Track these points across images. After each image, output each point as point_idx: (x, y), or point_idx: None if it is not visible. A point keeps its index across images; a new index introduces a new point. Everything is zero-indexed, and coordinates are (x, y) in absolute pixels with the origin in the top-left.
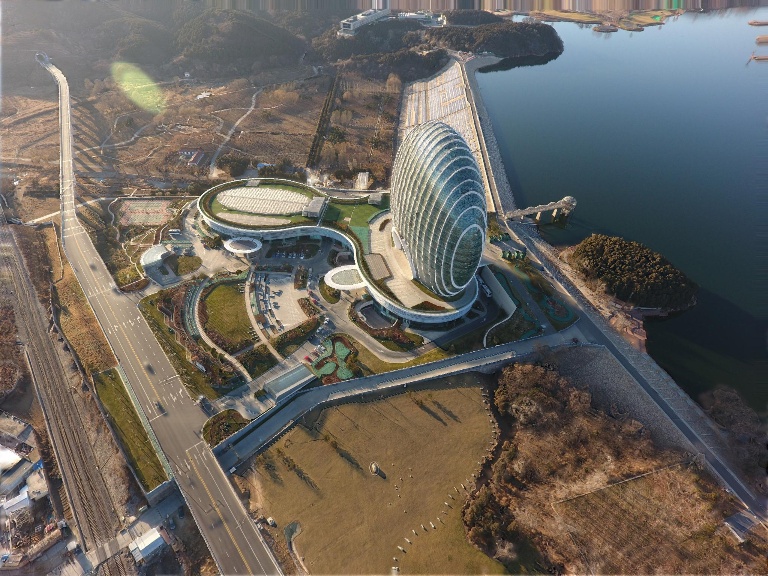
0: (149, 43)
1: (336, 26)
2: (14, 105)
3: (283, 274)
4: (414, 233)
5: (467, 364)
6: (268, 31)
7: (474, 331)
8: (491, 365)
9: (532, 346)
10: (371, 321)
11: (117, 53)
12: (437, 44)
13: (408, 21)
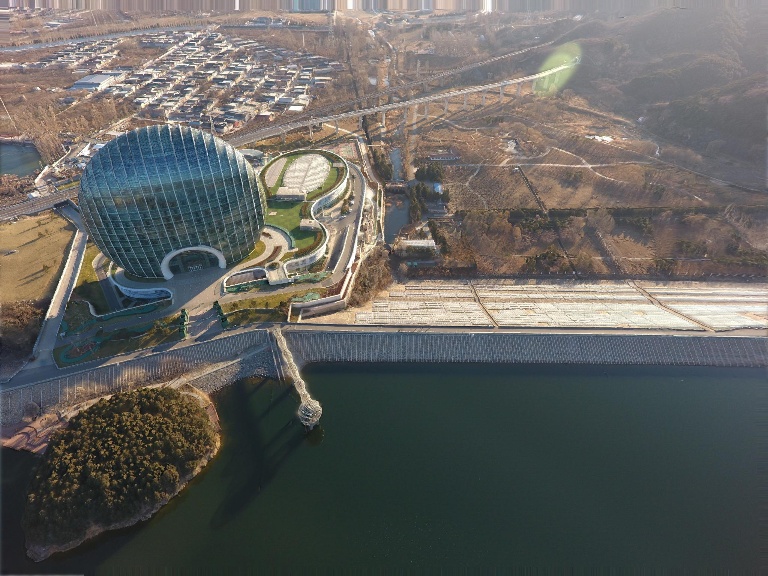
0: (671, 81)
1: None
2: None
3: None
4: None
5: (63, 290)
6: None
7: (105, 302)
8: None
9: None
10: None
11: None
12: None
13: None
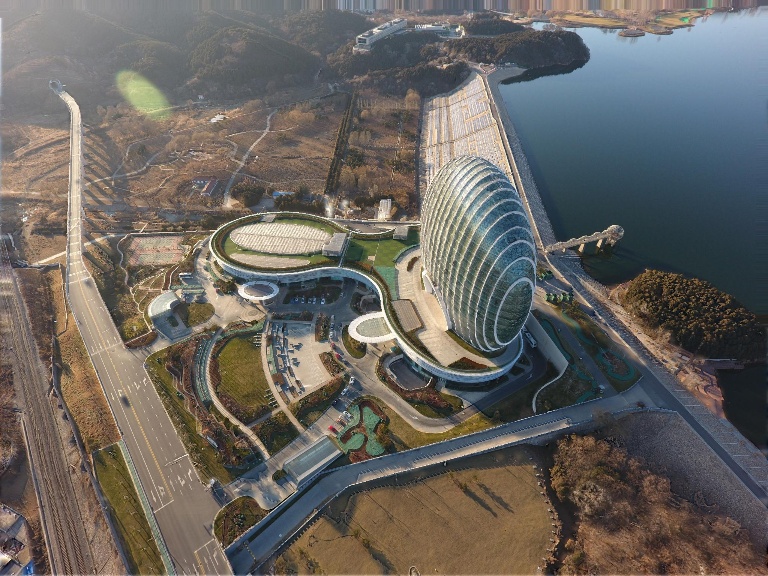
0: (162, 66)
1: (351, 41)
2: (27, 135)
3: (302, 323)
4: (450, 283)
5: (516, 435)
6: (282, 49)
7: (520, 391)
8: (544, 436)
9: (592, 414)
10: (401, 378)
11: (130, 77)
12: (457, 56)
13: (425, 33)
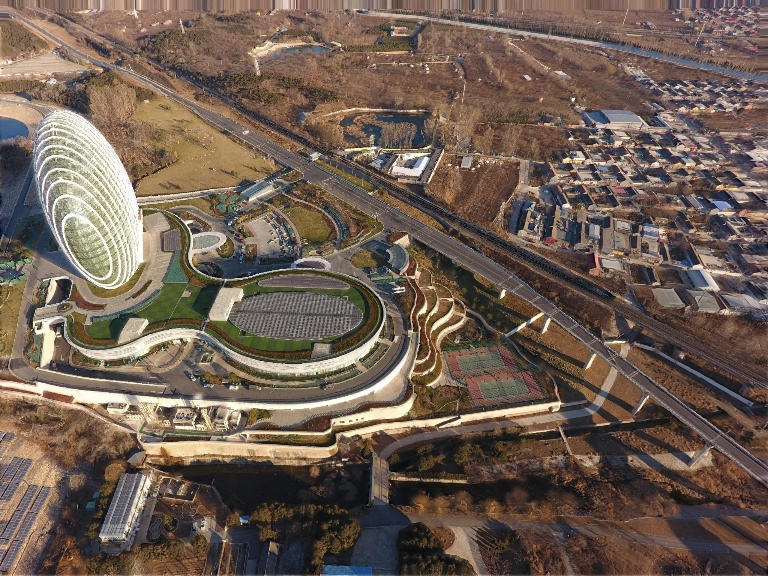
0: None
1: None
2: None
3: None
4: None
5: None
6: None
7: None
8: None
9: None
10: None
11: None
12: None
13: None
